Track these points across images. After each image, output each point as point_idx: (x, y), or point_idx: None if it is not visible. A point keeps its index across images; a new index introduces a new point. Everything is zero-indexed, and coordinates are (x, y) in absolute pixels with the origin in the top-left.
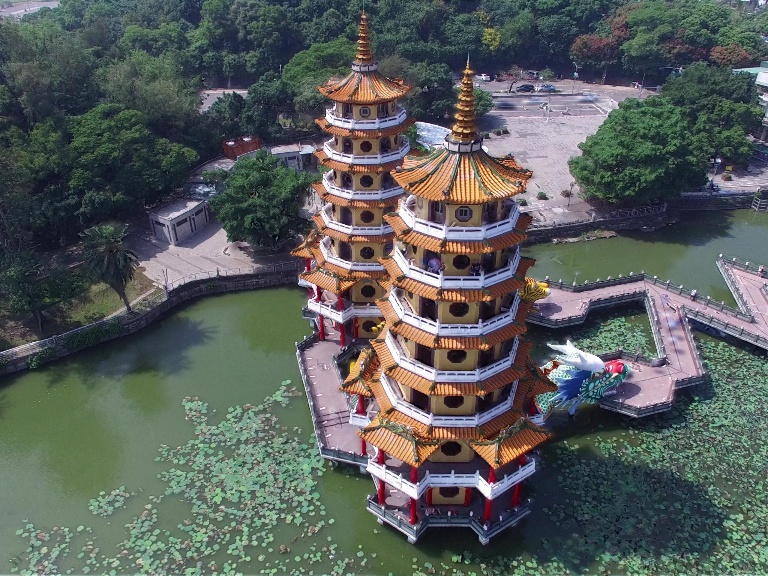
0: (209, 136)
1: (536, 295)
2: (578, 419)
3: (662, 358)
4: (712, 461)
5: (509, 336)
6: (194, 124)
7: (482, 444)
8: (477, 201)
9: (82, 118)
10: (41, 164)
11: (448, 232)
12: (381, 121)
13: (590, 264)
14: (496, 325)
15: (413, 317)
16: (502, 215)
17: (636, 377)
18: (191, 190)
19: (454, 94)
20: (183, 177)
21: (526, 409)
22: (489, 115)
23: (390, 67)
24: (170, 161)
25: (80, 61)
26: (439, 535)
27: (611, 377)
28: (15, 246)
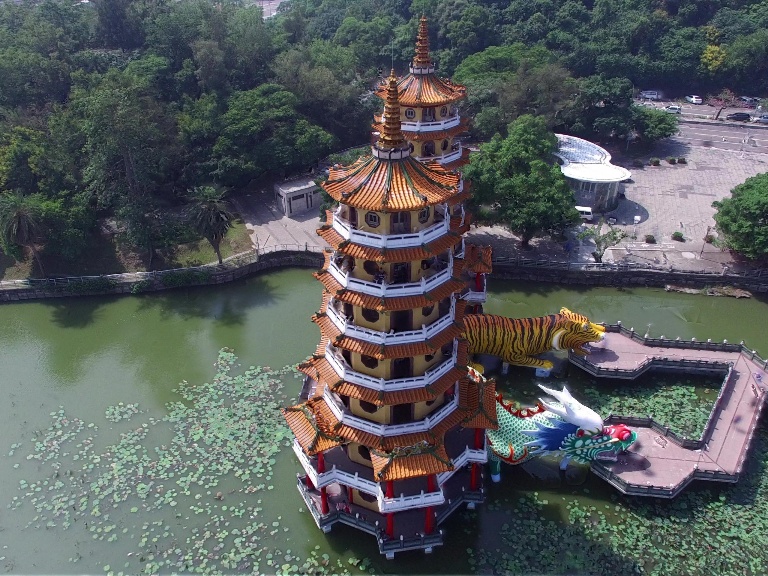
0: (360, 124)
1: (586, 336)
2: (576, 477)
3: (696, 441)
4: (694, 571)
5: (414, 353)
6: (349, 111)
7: (378, 454)
8: (371, 208)
9: (243, 94)
10: (195, 128)
11: (352, 234)
12: (423, 124)
13: (708, 323)
14: (404, 339)
15: (333, 312)
16: (418, 229)
17: (653, 452)
18: (322, 170)
19: (628, 113)
20: (312, 157)
21: (469, 440)
22: (674, 141)
23: (548, 76)
24: (303, 141)
25: (270, 45)
26: (348, 533)
27: (608, 441)
28: (140, 191)
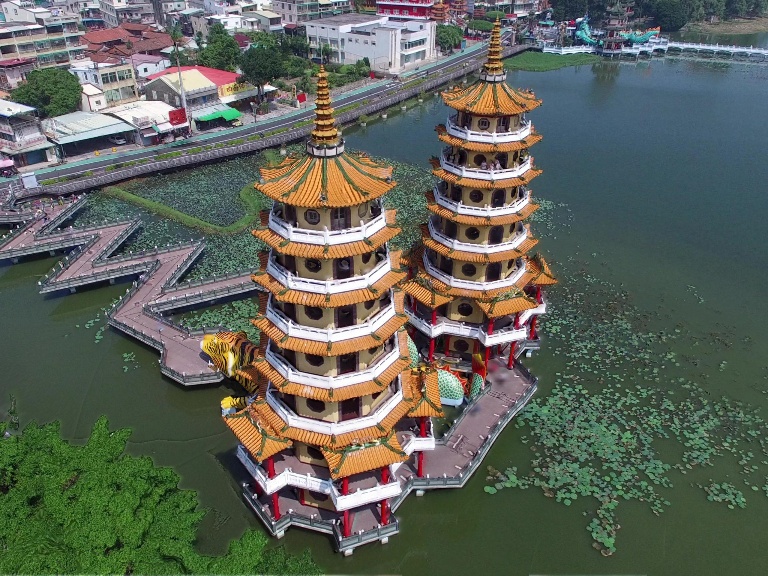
0: None
1: None
2: None
3: None
4: None
5: None
6: None
7: None
8: None
9: None
10: None
11: None
12: None
13: None
14: None
15: None
16: None
17: None
18: None
19: None
20: None
21: None
22: None
23: None
24: None
25: None
26: None
27: None
28: None
